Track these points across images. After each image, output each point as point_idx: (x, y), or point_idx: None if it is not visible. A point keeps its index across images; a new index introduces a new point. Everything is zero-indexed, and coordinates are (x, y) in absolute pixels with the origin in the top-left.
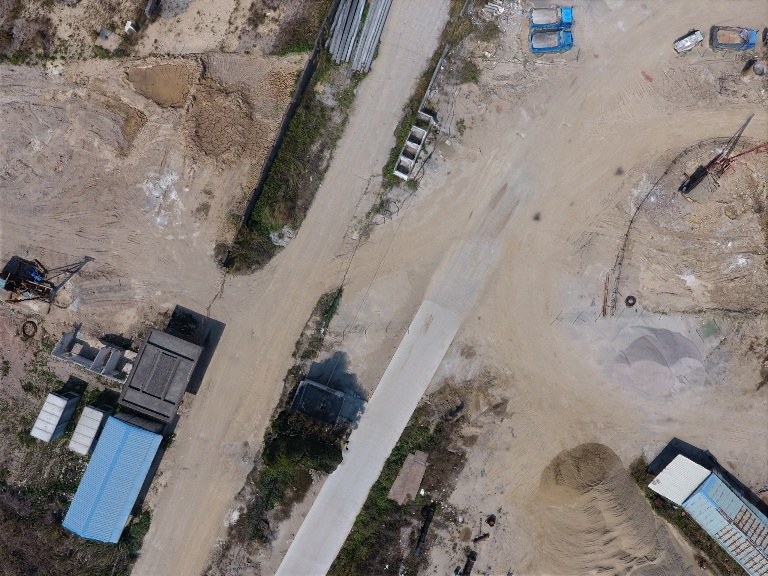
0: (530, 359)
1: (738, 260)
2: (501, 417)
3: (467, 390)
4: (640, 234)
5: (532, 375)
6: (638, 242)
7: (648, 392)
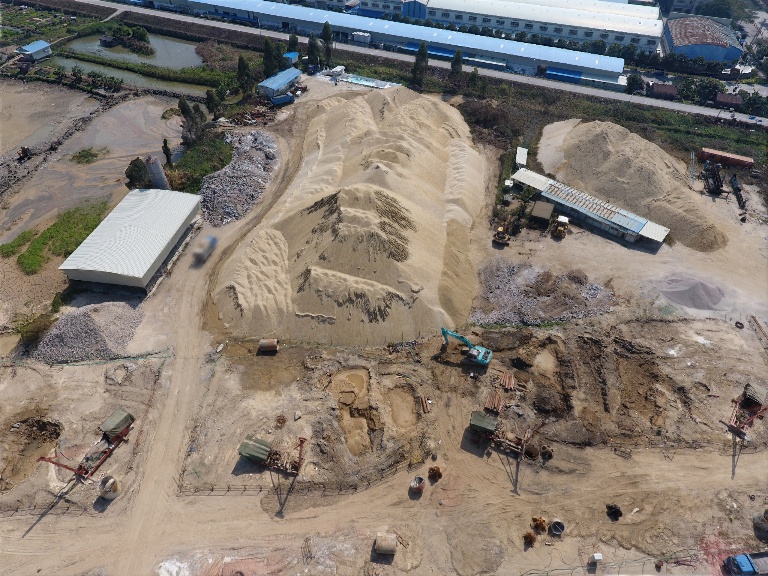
0: None
1: (675, 353)
2: None
3: None
4: (765, 370)
5: None
6: (762, 364)
7: None
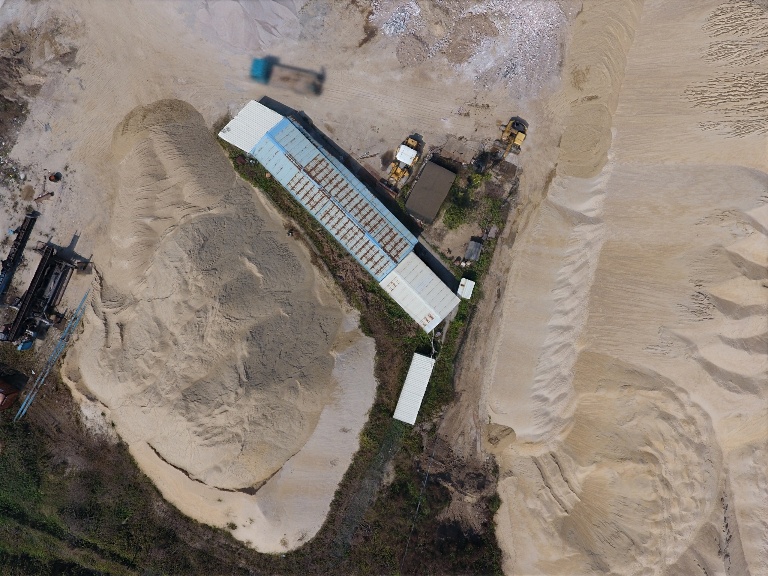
0: (103, 6)
1: None
2: (69, 67)
3: (32, 38)
4: None
5: (105, 23)
6: None
7: (234, 44)
